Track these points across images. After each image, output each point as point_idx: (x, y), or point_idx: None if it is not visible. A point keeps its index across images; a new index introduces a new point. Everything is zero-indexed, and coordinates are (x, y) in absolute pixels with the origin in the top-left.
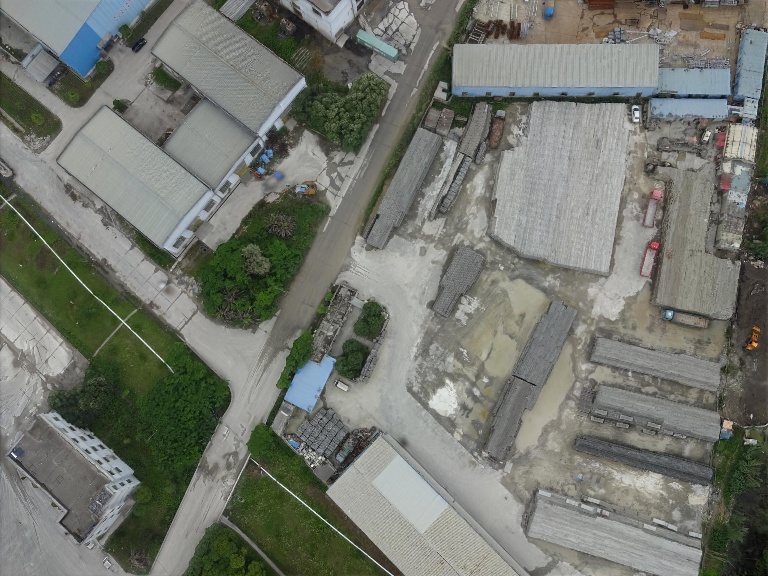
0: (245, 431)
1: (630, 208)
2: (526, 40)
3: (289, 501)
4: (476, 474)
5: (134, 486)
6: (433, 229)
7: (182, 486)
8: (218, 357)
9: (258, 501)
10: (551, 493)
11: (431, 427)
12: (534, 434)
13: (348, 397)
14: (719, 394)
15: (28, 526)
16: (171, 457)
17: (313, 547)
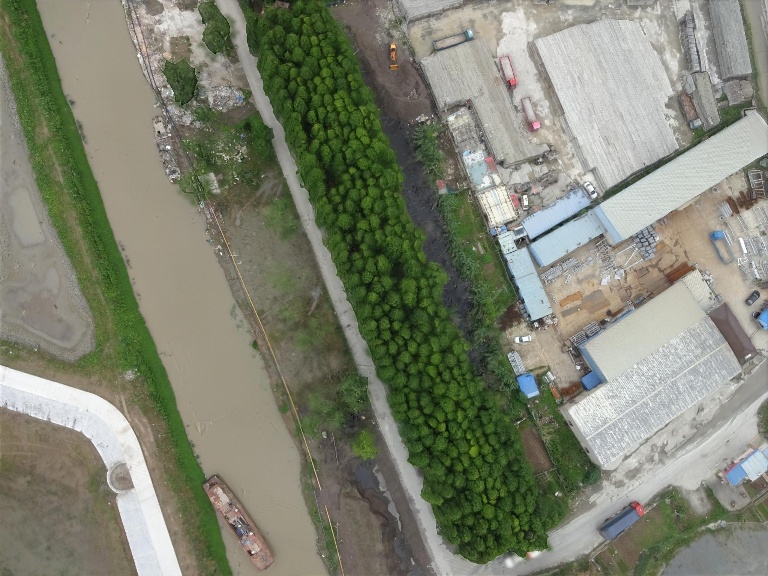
0: None
1: (545, 109)
2: (716, 205)
3: None
4: None
5: None
6: (681, 6)
7: None
8: None
9: None
10: None
11: None
12: None
13: None
14: (393, 1)
15: None
16: None
17: None
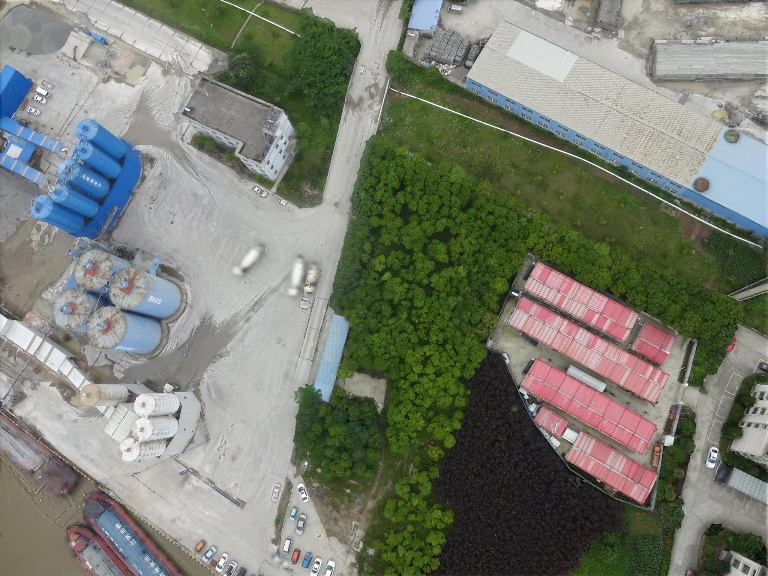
0: (379, 66)
1: None
2: None
3: (432, 110)
4: (594, 47)
5: (293, 129)
6: None
7: (334, 125)
8: (340, 19)
9: (405, 117)
10: (666, 40)
11: (543, 22)
12: (637, 3)
13: (463, 19)
14: None
15: (205, 195)
16: (322, 91)
17: (464, 139)
